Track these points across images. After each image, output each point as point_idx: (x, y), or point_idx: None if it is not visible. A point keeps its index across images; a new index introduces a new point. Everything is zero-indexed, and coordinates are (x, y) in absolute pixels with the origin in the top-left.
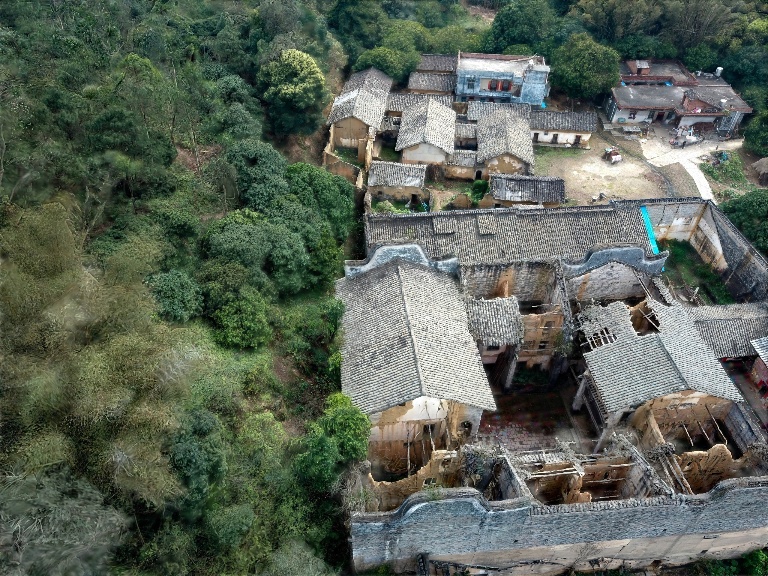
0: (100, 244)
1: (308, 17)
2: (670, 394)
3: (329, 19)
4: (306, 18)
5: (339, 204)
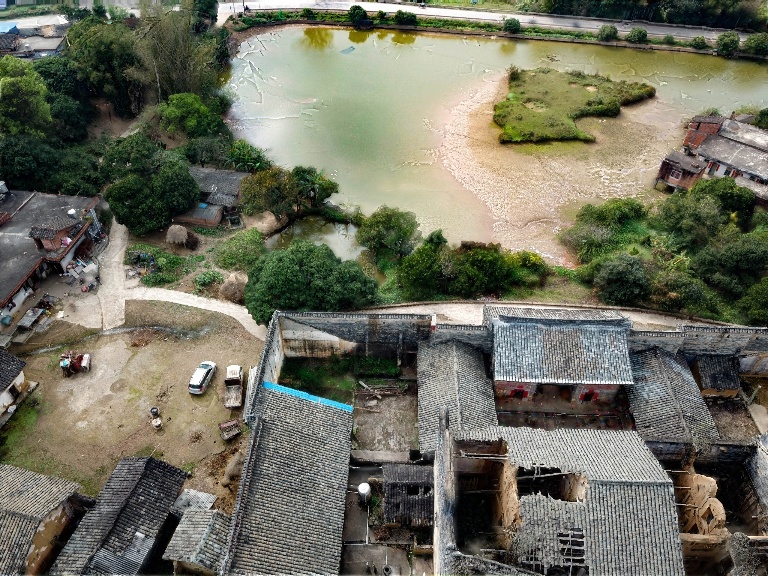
0: None
1: None
2: None
3: None
4: None
5: None
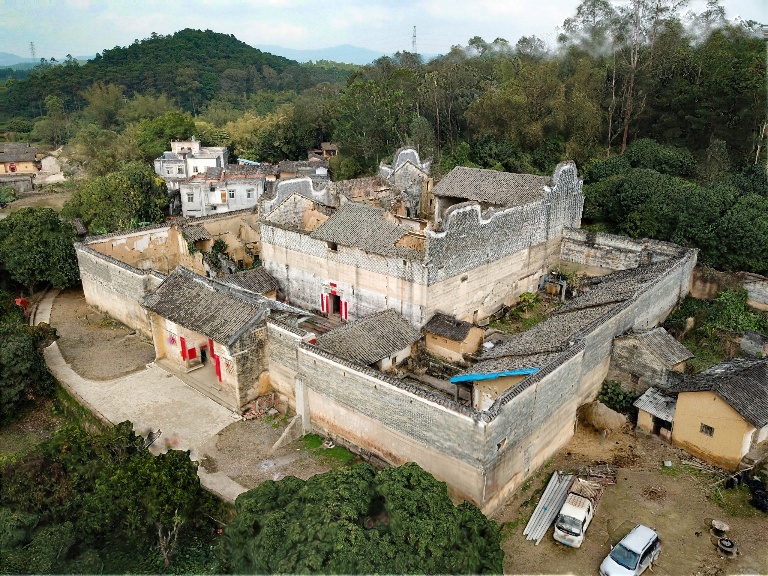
0: (648, 139)
1: None
2: None
3: None
4: None
5: None
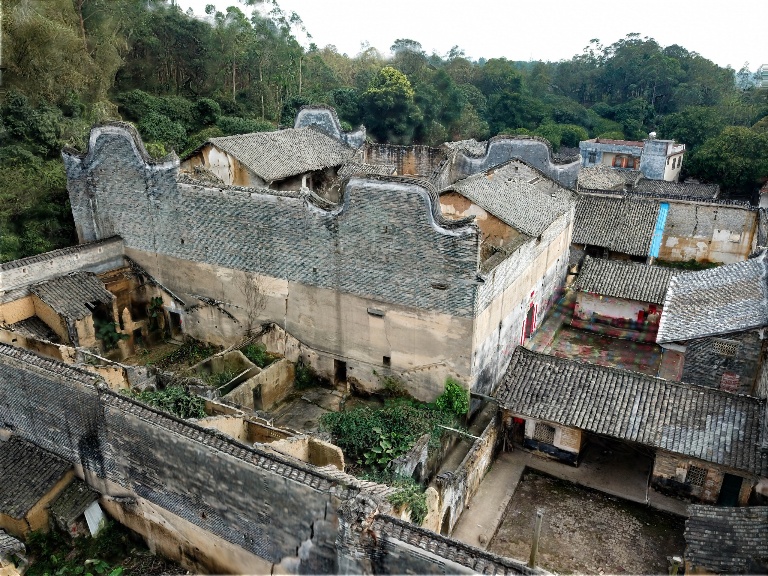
0: None
1: (443, 78)
2: (441, 204)
3: (489, 109)
4: (442, 79)
5: None
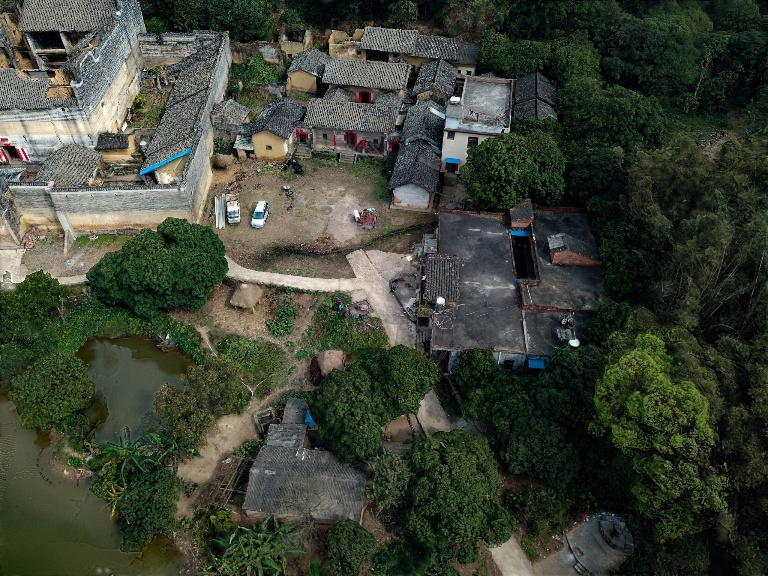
0: None
1: None
2: None
3: None
4: None
5: (218, 8)
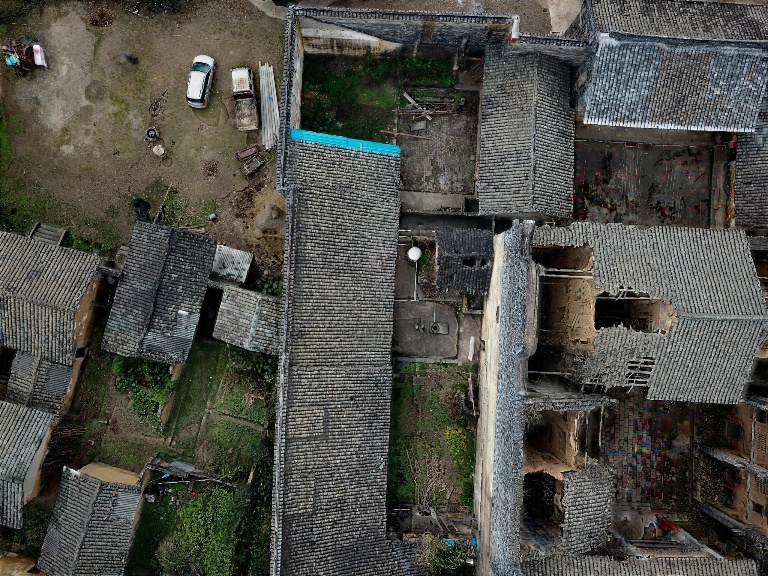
0: None
1: None
2: None
3: None
4: None
5: None
